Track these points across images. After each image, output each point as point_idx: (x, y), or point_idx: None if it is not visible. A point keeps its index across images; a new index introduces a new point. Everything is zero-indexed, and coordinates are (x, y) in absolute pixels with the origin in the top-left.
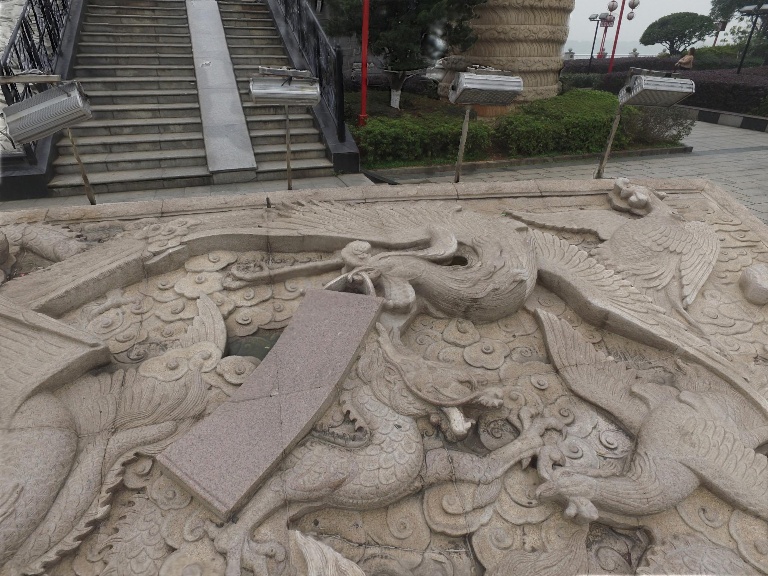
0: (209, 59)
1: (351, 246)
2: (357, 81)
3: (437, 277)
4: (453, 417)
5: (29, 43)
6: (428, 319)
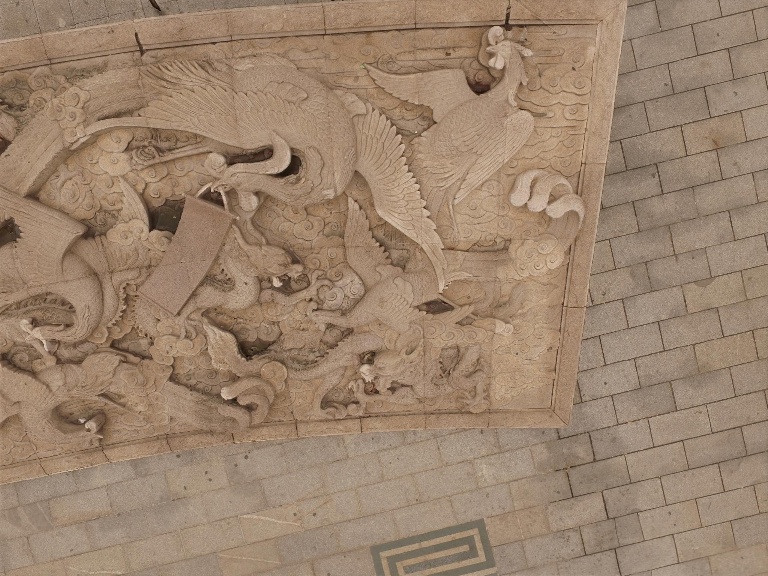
0: None
1: (211, 159)
2: None
3: (272, 191)
4: (274, 280)
5: None
6: None
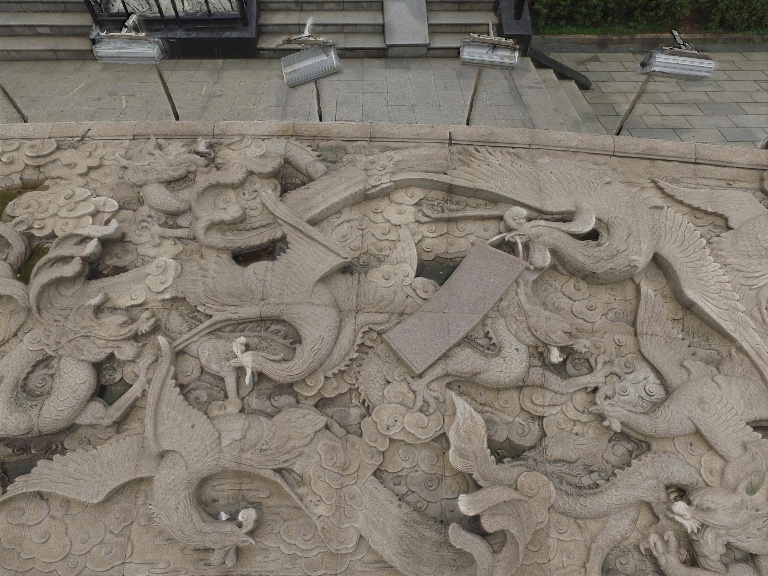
0: None
1: (512, 211)
2: None
3: (570, 250)
4: (553, 352)
5: None
6: (554, 273)
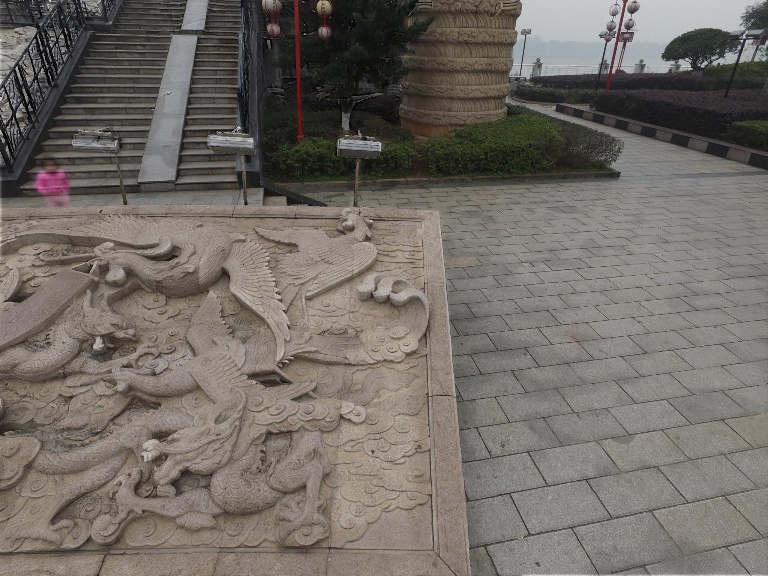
0: (171, 89)
1: (102, 245)
2: (331, 100)
3: (140, 267)
4: (96, 341)
5: (20, 83)
6: (143, 292)
